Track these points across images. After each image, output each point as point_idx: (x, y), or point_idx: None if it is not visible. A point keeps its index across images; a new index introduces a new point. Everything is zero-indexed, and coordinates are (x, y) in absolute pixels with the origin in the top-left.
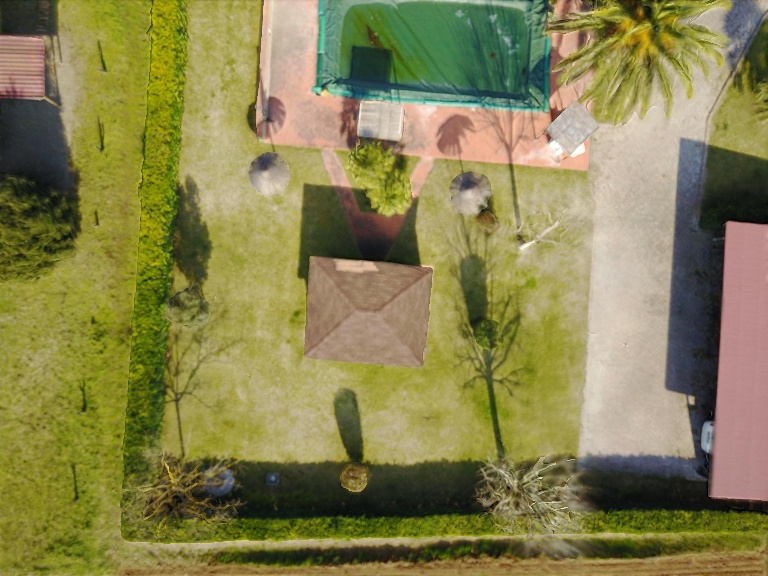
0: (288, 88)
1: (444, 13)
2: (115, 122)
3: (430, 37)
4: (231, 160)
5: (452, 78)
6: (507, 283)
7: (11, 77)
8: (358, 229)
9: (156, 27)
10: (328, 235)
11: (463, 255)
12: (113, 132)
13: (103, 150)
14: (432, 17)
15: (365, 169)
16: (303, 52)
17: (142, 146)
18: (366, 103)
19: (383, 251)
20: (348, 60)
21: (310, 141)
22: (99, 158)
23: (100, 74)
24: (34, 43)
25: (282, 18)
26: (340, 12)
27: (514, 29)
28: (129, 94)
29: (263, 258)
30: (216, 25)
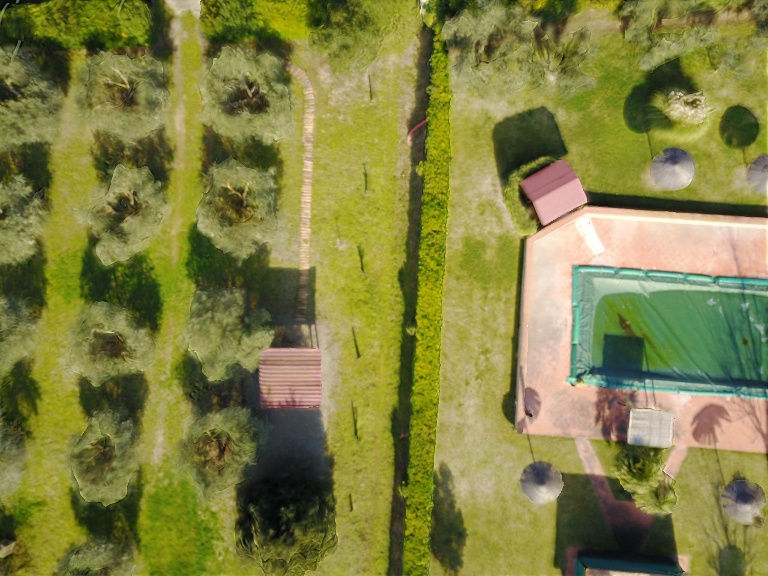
0: (542, 378)
1: (695, 301)
2: (368, 406)
3: (681, 325)
4: (486, 448)
5: (705, 366)
6: (767, 575)
7: (291, 388)
8: (613, 518)
9: (421, 328)
10: (583, 524)
11: (721, 546)
12: (366, 415)
13: (357, 434)
14: (683, 305)
15: (640, 482)
16: (557, 343)
17: (391, 425)
18: (636, 411)
19: (639, 541)
20: (600, 349)
21: (565, 430)
22: (353, 441)
23: (354, 359)
24: (312, 353)
25: (536, 309)
26: (592, 302)
27: (766, 317)
28: (380, 376)
29: (519, 547)
30: (470, 316)
